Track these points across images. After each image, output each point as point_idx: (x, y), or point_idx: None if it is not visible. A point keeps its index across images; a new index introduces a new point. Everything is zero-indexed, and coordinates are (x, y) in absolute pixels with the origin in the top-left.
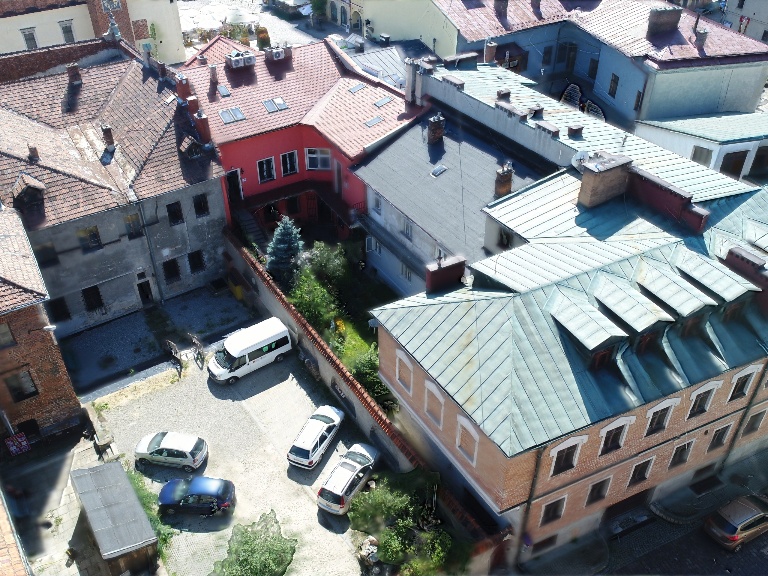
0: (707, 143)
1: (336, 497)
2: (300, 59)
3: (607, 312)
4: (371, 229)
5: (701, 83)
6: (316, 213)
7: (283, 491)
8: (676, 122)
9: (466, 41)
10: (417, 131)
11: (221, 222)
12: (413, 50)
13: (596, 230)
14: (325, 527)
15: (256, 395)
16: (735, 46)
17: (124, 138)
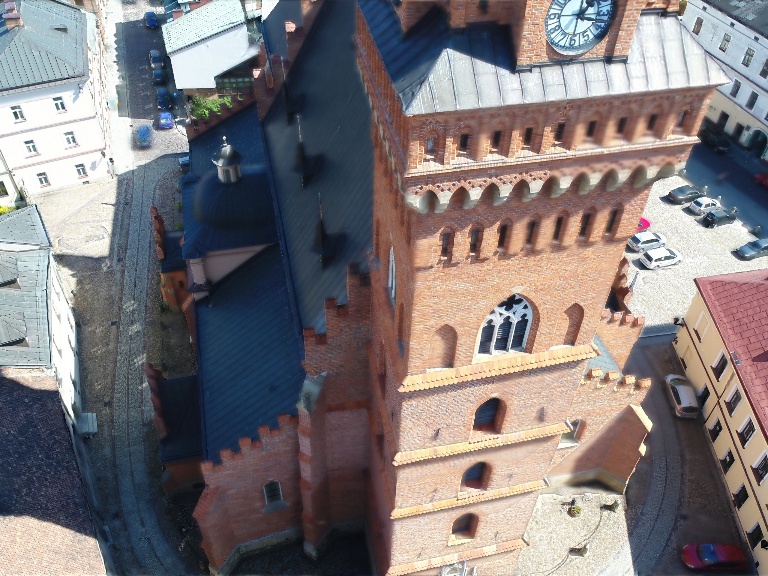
0: None
1: None
2: None
3: None
4: None
5: None
6: None
7: None
8: None
9: None
10: None
11: None
12: None
13: None
14: None
15: None
16: None
17: None
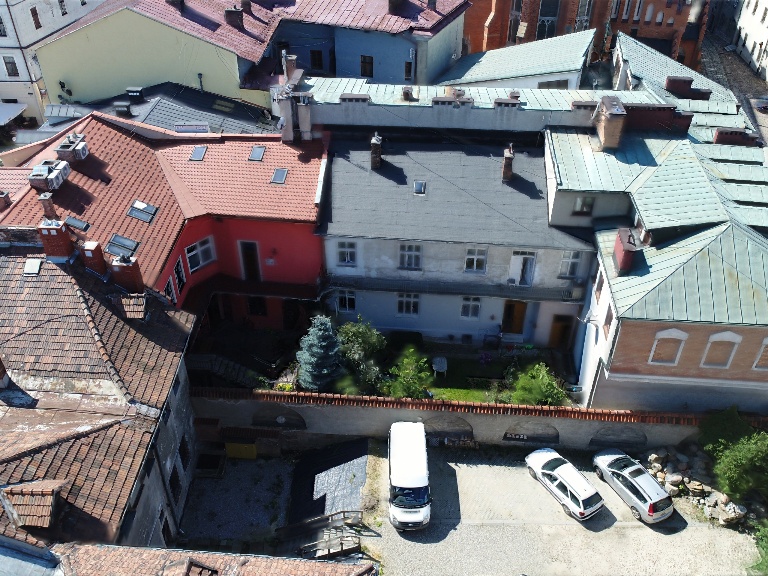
0: (560, 76)
1: (667, 500)
2: (96, 148)
3: (755, 204)
4: (363, 284)
5: (443, 40)
6: (207, 320)
7: (613, 545)
8: (473, 75)
9: (254, 63)
10: (343, 164)
11: (185, 385)
12: (179, 95)
13: (642, 161)
14: (674, 533)
15: (461, 506)
16: (447, 2)
17: (6, 357)
